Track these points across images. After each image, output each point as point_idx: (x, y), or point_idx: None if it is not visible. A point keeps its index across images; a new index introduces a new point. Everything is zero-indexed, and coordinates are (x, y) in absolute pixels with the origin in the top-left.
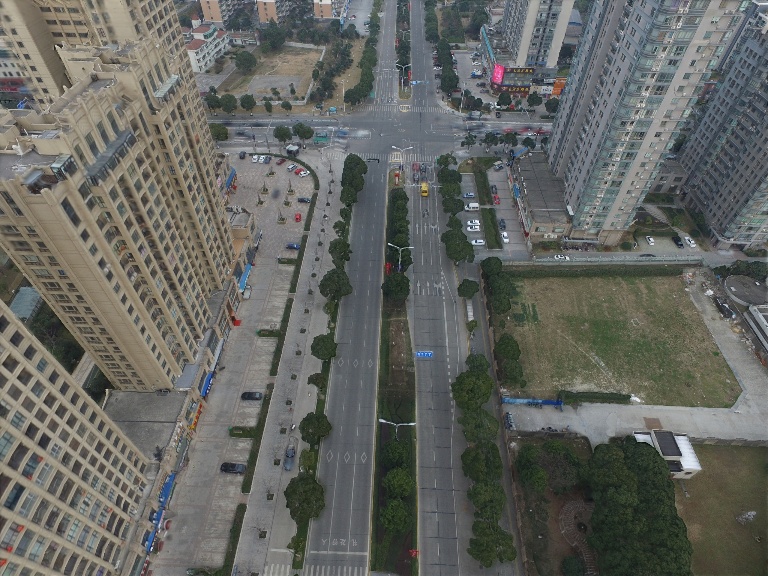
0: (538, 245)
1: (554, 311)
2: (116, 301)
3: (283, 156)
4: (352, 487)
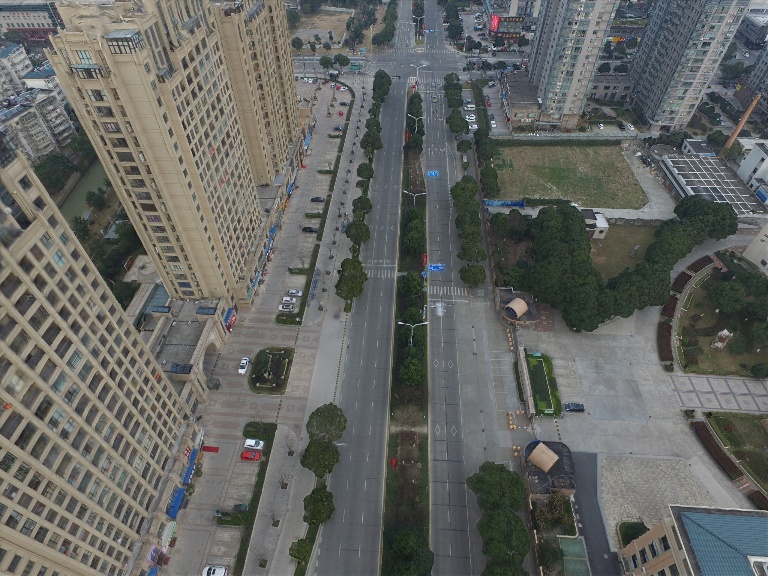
0: (517, 128)
1: (525, 163)
2: (252, 100)
3: (326, 79)
4: (386, 240)
